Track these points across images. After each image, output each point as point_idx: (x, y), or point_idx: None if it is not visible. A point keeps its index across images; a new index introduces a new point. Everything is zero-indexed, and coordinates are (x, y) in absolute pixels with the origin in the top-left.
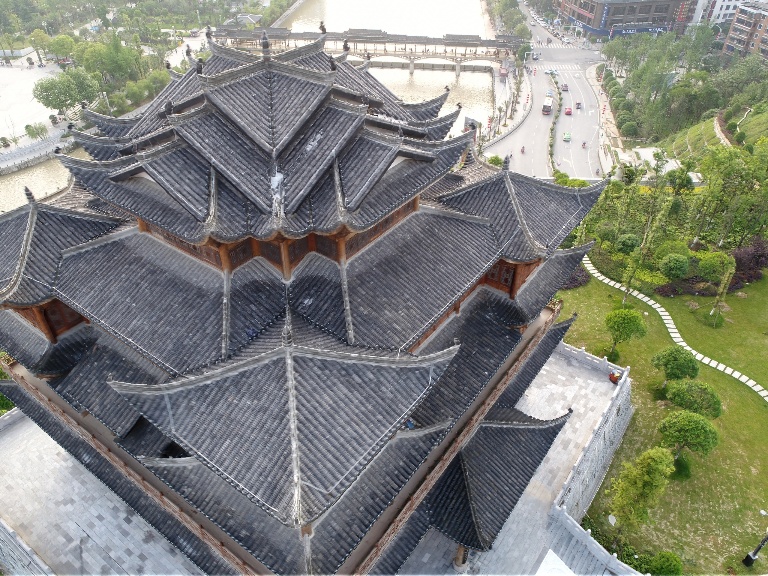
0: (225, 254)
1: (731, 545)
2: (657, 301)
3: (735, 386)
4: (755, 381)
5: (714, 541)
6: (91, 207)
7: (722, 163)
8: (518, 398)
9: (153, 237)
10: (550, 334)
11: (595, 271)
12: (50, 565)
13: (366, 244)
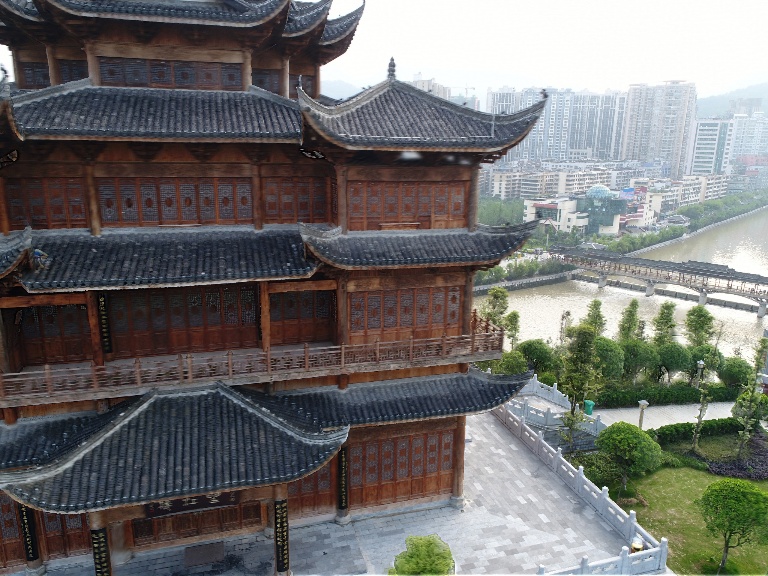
0: (14, 63)
1: None
2: None
3: None
4: None
5: None
6: None
7: None
8: (341, 420)
9: None
10: (485, 389)
11: None
12: None
13: (143, 86)
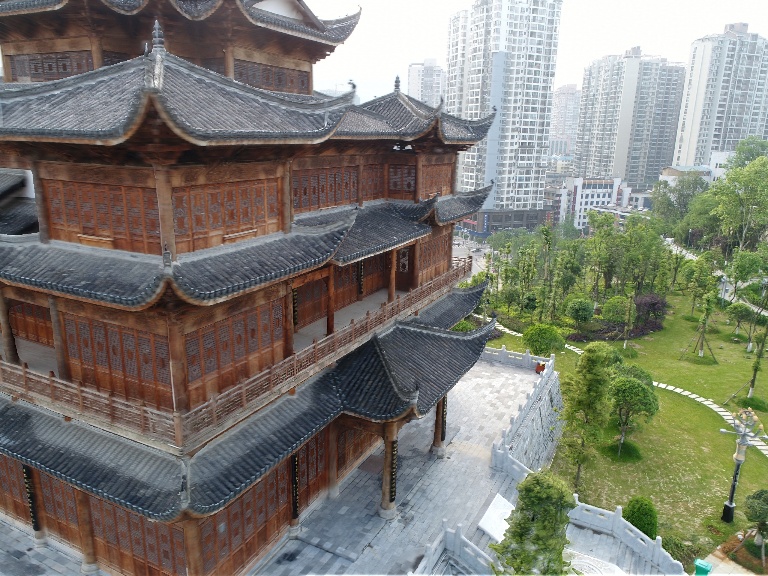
0: (98, 51)
1: (704, 508)
2: (571, 345)
3: (664, 393)
4: (682, 389)
5: (685, 506)
6: None
7: (601, 224)
8: None
9: (18, 83)
10: (465, 298)
11: (507, 330)
12: None
13: None
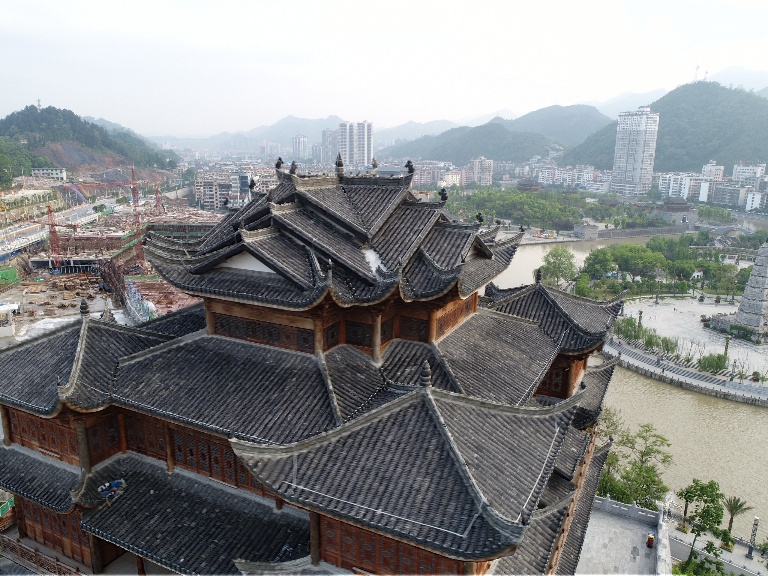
0: None
1: None
2: None
3: None
4: None
5: None
6: None
7: None
8: None
9: None
10: None
11: None
12: None
13: (242, 338)
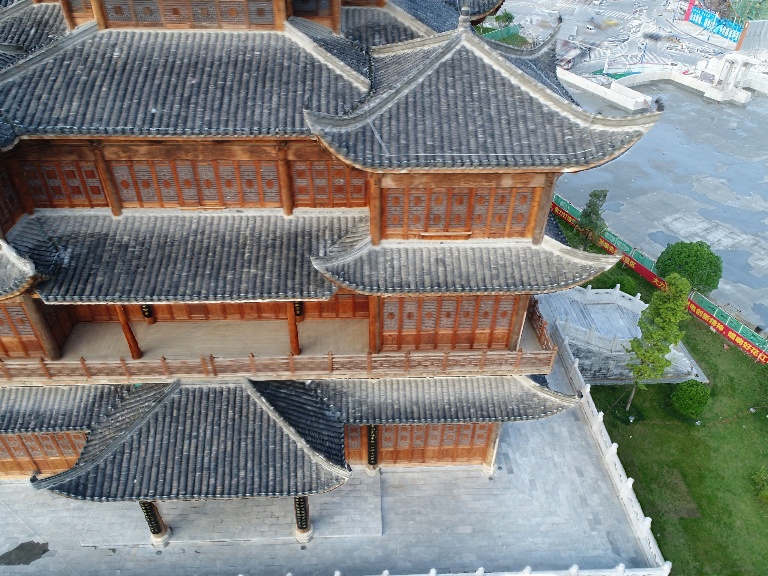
0: None
1: None
2: None
3: None
4: None
5: None
6: (373, 85)
7: None
8: None
9: None
10: None
11: None
12: (562, 366)
13: None
